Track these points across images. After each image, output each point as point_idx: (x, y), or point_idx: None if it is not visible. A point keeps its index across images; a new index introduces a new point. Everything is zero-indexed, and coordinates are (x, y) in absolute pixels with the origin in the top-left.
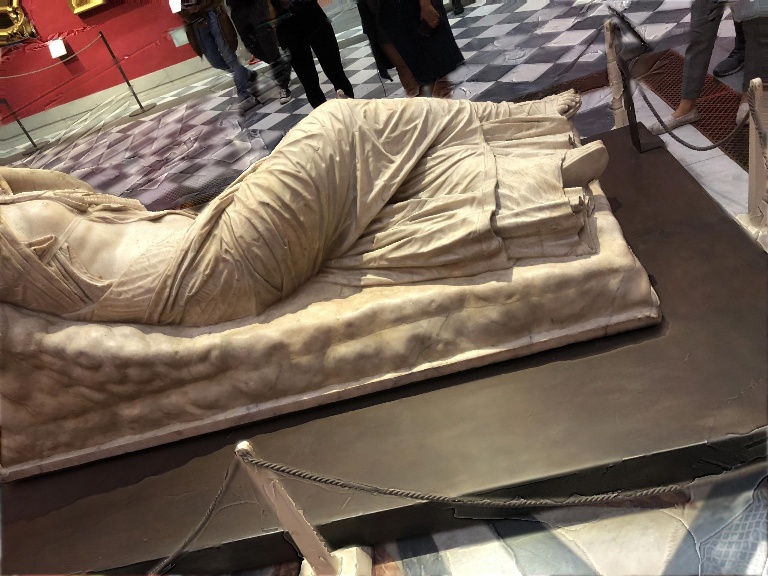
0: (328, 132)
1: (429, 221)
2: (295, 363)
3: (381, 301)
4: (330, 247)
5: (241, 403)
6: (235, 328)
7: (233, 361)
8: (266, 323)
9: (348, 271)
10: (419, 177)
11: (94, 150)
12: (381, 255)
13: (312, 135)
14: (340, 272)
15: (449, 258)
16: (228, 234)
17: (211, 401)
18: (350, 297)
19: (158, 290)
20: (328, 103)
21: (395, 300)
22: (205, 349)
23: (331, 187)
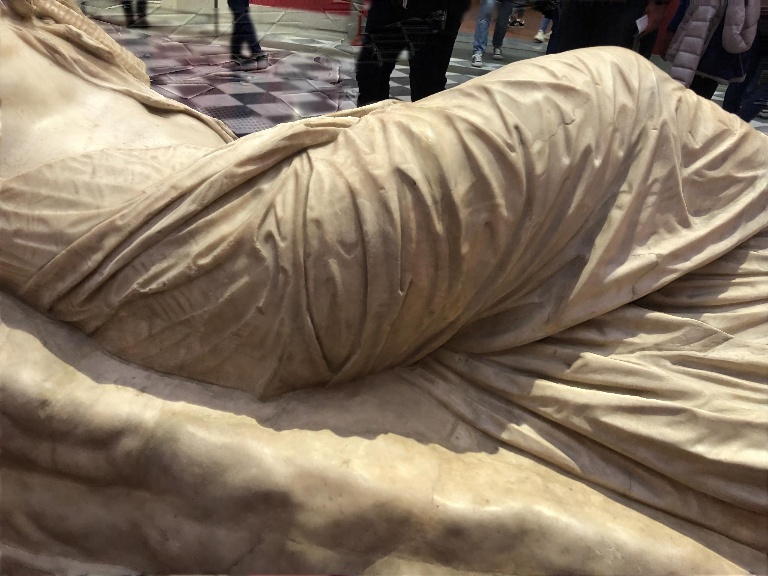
0: (603, 99)
1: (723, 386)
2: (293, 551)
3: (547, 510)
4: (466, 326)
5: (133, 562)
6: (201, 405)
7: (160, 479)
8: (273, 428)
9: (481, 392)
10: (715, 280)
11: (133, 5)
12: (584, 405)
13: (569, 88)
14: (462, 385)
15: (759, 500)
16: (291, 203)
17: (71, 532)
18: (470, 455)
19: (77, 246)
20: (614, 48)
21: (582, 526)
22: (112, 426)
23: (552, 214)
